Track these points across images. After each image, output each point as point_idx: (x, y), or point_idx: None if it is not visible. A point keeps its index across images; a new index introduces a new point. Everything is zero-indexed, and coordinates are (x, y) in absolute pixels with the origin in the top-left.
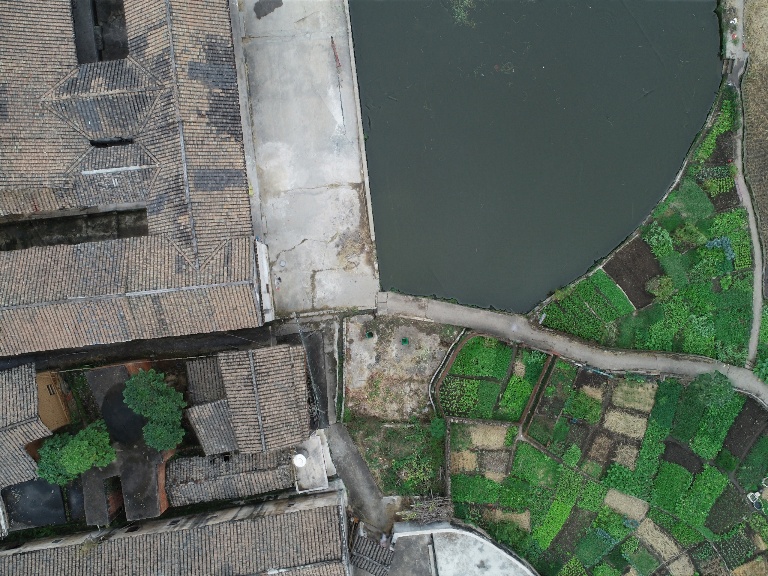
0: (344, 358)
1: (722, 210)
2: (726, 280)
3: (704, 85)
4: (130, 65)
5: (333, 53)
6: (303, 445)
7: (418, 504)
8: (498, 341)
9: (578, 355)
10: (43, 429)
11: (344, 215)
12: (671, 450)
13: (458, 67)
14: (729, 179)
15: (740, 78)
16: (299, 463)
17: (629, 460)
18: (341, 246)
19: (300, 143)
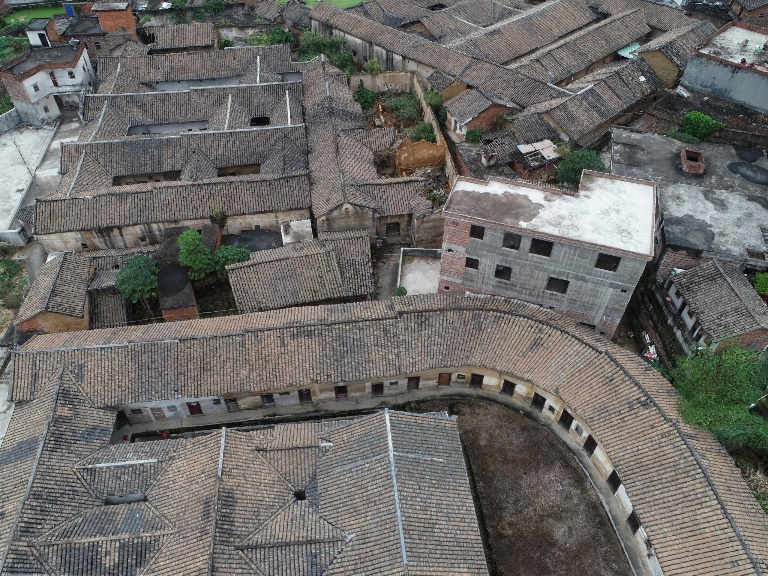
0: None
1: None
2: None
3: None
4: None
5: None
6: None
7: None
8: None
9: None
10: None
11: None
12: None
13: None
14: None
15: None
16: None
17: None
18: None
19: None
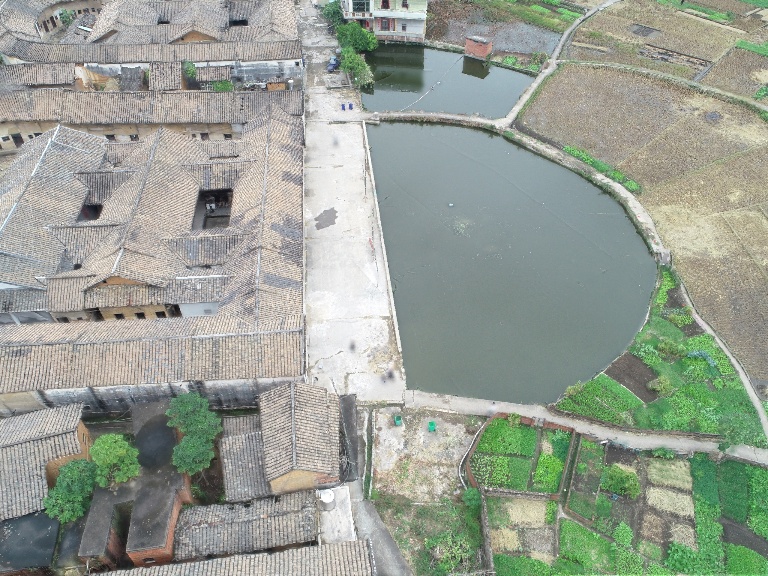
0: (373, 441)
1: (692, 336)
2: (718, 382)
3: (646, 271)
4: (229, 229)
5: (370, 246)
6: None
7: (457, 573)
8: (521, 423)
9: (601, 436)
10: (75, 444)
11: (375, 336)
12: (730, 531)
13: (461, 256)
14: (688, 316)
15: (670, 263)
16: (327, 497)
17: (688, 541)
18: (372, 356)
19: (342, 292)
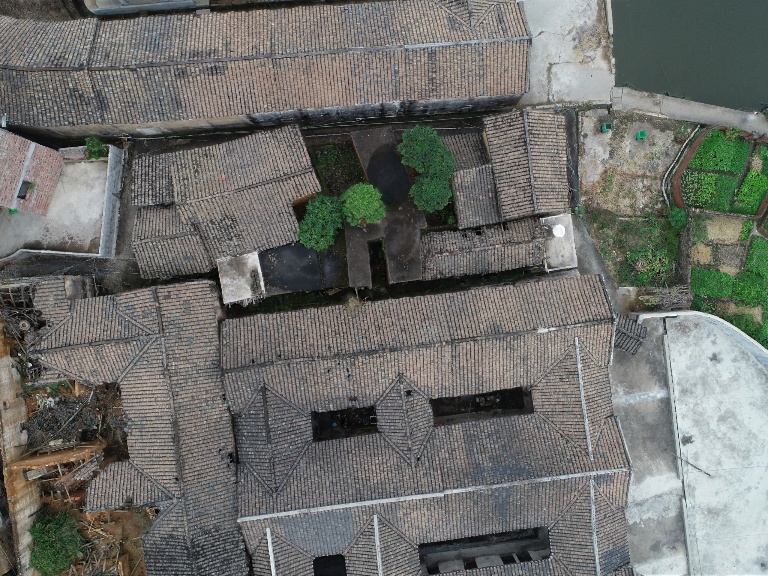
0: (579, 151)
1: None
2: None
3: None
4: None
5: None
6: (553, 223)
7: (661, 289)
8: None
9: None
10: (314, 183)
11: (582, 8)
12: None
13: None
14: None
15: None
16: (559, 233)
17: None
18: (578, 40)
19: None
